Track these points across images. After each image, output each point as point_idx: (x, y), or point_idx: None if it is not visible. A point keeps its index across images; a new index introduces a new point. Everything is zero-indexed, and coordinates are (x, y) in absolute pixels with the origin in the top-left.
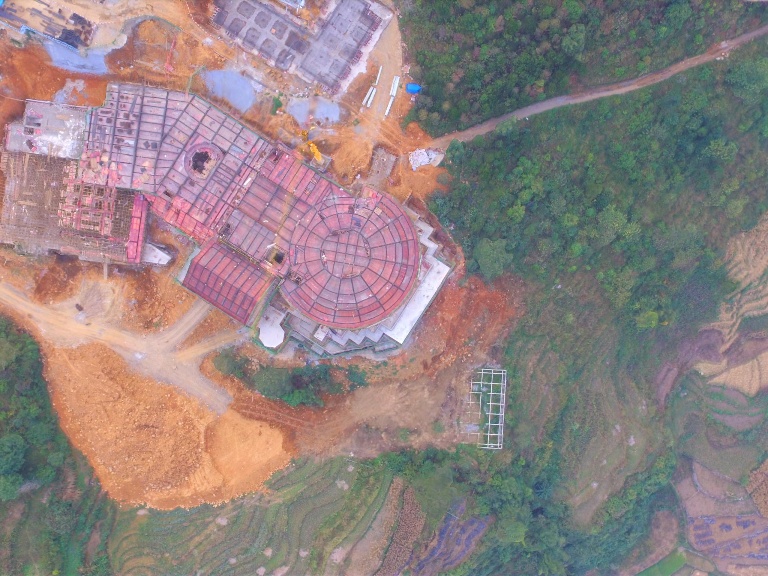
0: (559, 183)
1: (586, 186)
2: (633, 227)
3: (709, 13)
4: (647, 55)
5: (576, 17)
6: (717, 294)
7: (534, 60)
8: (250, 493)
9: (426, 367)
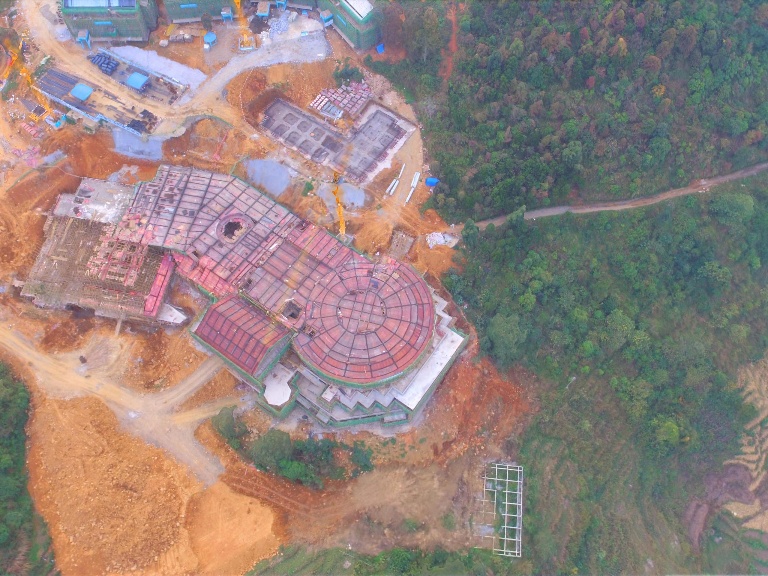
0: (567, 279)
1: (593, 288)
2: (642, 333)
3: (686, 151)
4: (637, 178)
5: (573, 136)
6: (736, 422)
7: (539, 165)
8: None
9: (436, 453)
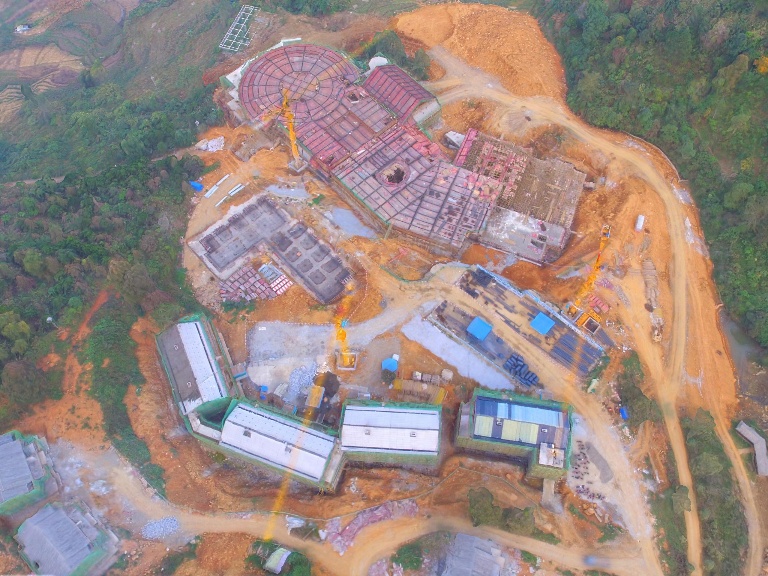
0: (116, 132)
1: None
2: (76, 115)
3: None
4: None
5: None
6: None
7: (86, 179)
8: (433, 4)
9: None
